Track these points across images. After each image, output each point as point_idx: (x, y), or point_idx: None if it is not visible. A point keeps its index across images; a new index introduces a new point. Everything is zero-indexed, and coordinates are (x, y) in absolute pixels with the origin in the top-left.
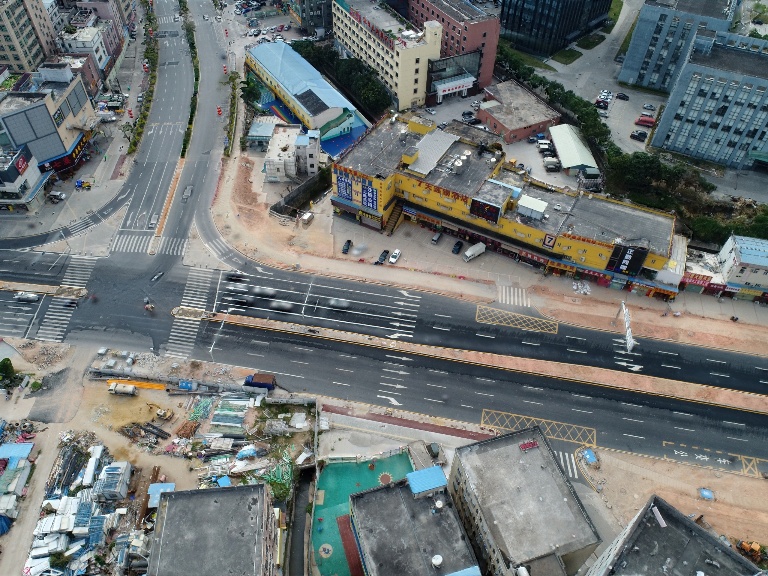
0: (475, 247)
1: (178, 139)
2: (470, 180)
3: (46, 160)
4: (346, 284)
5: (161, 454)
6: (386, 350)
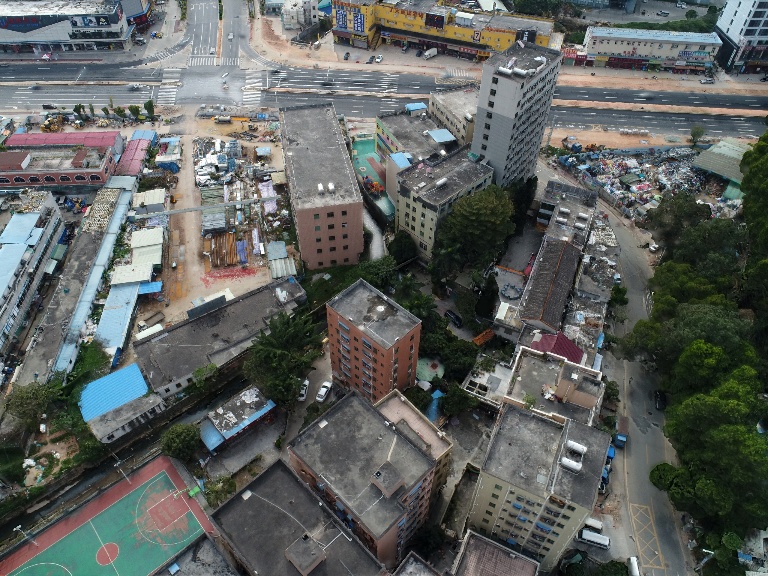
0: (430, 50)
1: (214, 11)
2: (424, 7)
3: (131, 16)
4: (350, 72)
5: (256, 142)
6: (381, 97)
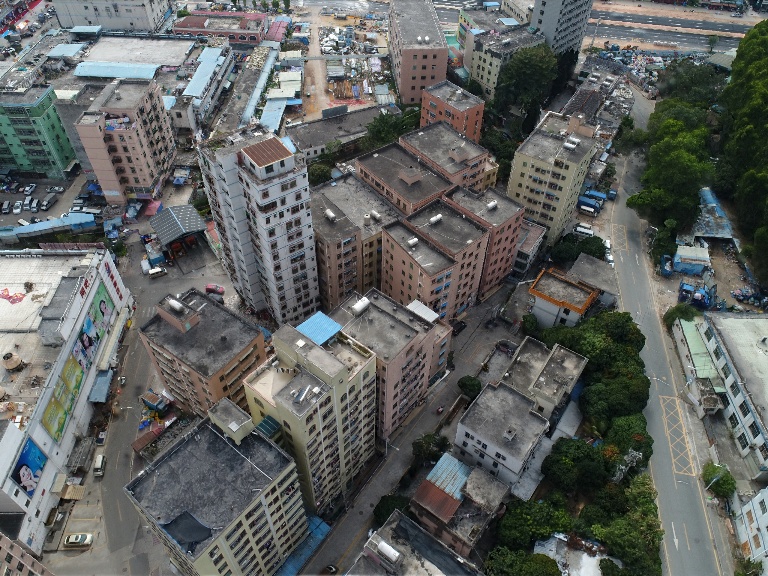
0: None
1: None
2: None
3: None
4: None
5: None
6: None
